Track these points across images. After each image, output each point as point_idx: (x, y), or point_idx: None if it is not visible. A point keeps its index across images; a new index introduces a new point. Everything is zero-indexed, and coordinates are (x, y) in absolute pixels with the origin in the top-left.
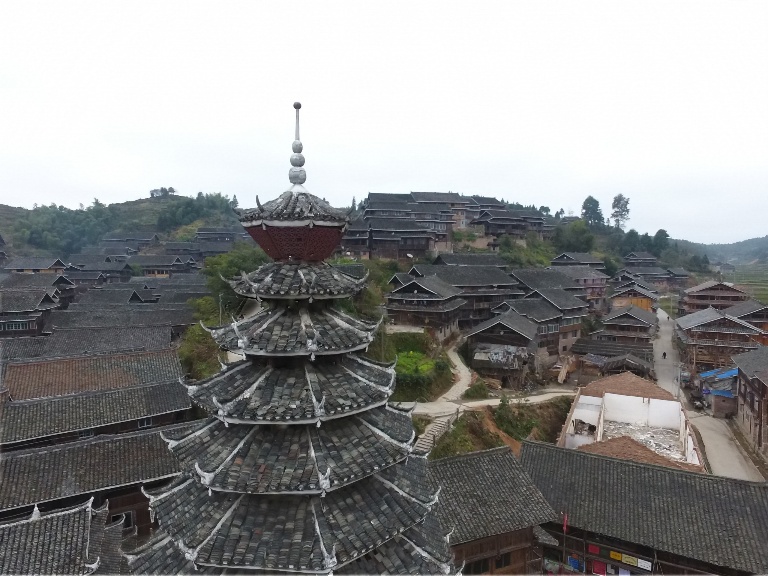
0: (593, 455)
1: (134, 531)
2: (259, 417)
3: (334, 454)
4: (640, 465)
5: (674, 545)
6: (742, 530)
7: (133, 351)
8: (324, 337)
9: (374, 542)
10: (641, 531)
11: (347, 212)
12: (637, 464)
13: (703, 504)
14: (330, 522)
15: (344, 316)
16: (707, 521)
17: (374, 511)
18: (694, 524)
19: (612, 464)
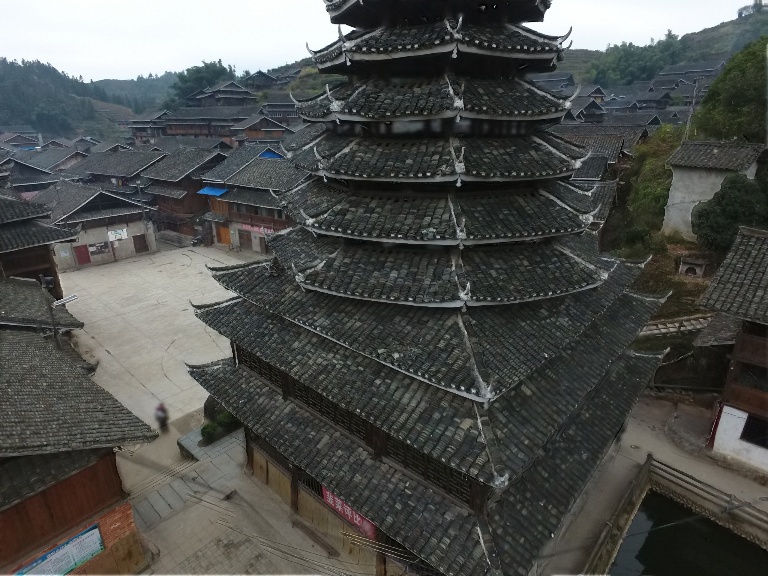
0: None
1: None
2: None
3: None
4: None
5: None
6: None
7: None
8: None
9: None
10: None
11: None
12: None
13: None
14: None
15: None
16: None
17: None
18: None
19: None
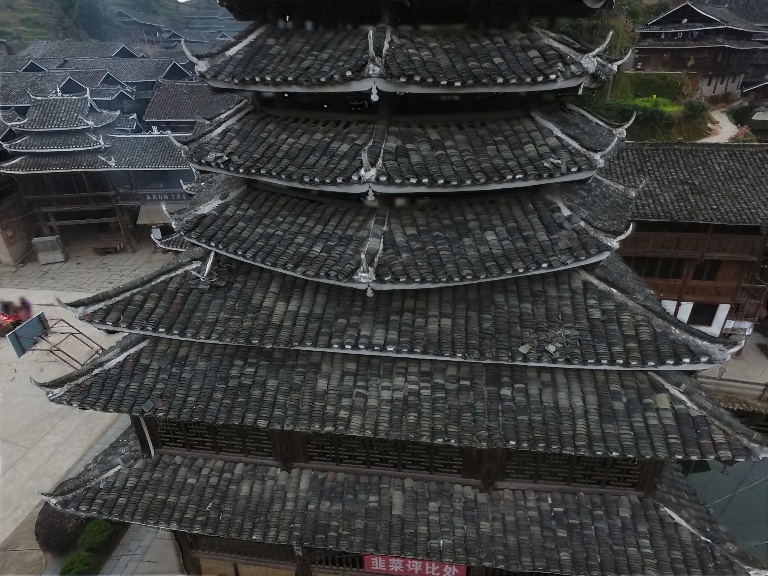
0: None
1: None
2: None
3: None
4: None
5: None
6: None
7: None
8: None
9: None
10: None
11: None
12: None
13: None
14: None
15: None
16: None
17: None
18: None
19: None
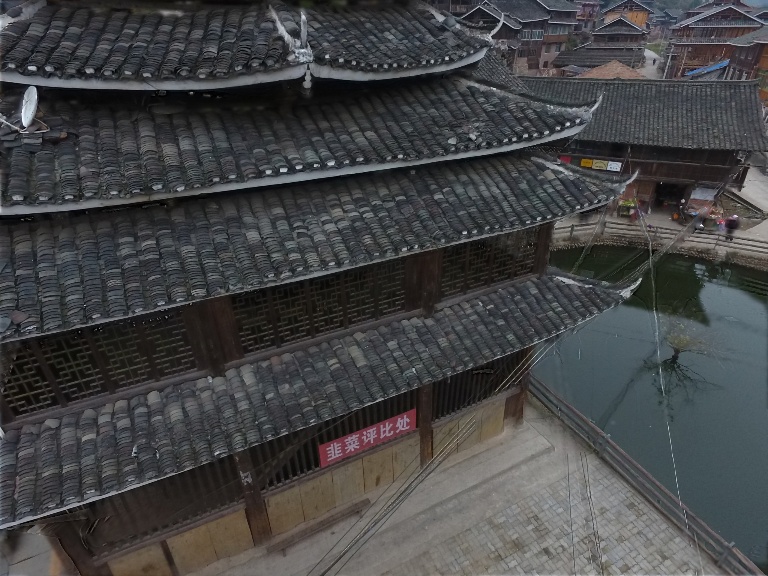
0: (577, 79)
1: None
2: None
3: None
4: (627, 82)
5: (650, 138)
6: (723, 120)
7: None
8: None
9: None
10: (618, 132)
11: None
12: (623, 81)
13: (687, 105)
14: None
15: None
16: (688, 117)
17: None
18: (674, 121)
19: (596, 85)
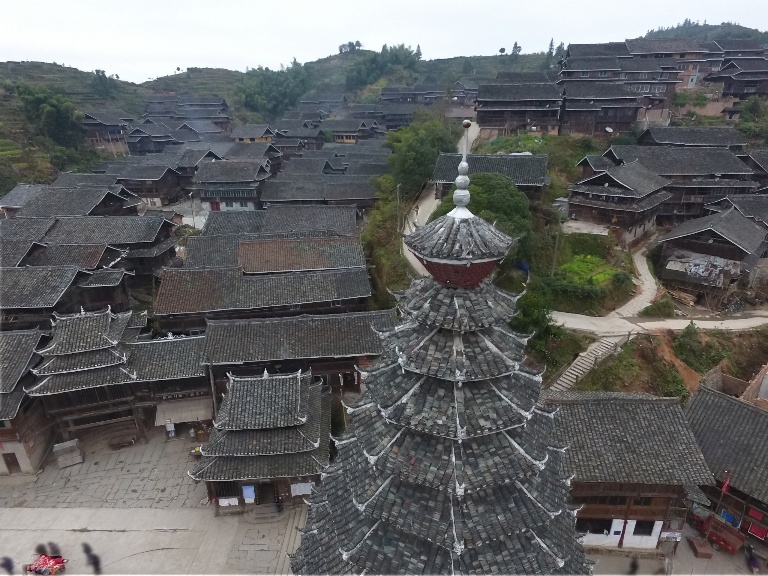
0: None
1: (329, 390)
2: (412, 426)
3: (472, 461)
4: None
5: None
6: None
7: (326, 232)
8: (472, 364)
9: (497, 536)
10: None
11: (507, 246)
12: None
13: None
14: (463, 511)
15: (496, 329)
16: None
17: (502, 507)
18: None
19: None
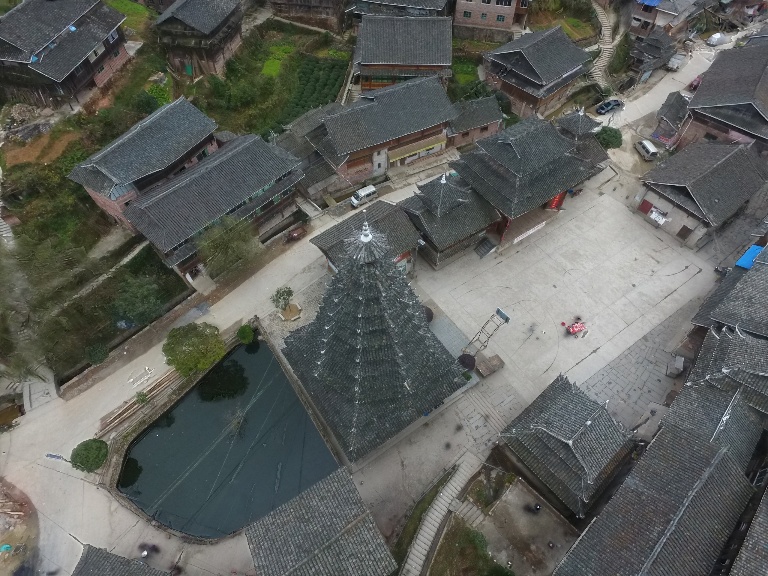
0: None
1: None
2: None
3: None
4: None
5: None
6: None
7: None
8: None
9: None
10: None
11: None
12: None
13: None
14: None
15: None
16: None
17: None
18: None
19: None
